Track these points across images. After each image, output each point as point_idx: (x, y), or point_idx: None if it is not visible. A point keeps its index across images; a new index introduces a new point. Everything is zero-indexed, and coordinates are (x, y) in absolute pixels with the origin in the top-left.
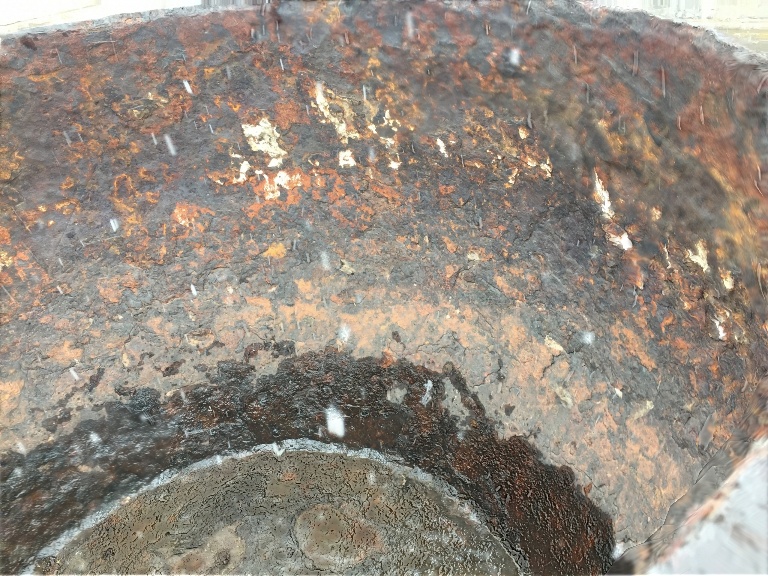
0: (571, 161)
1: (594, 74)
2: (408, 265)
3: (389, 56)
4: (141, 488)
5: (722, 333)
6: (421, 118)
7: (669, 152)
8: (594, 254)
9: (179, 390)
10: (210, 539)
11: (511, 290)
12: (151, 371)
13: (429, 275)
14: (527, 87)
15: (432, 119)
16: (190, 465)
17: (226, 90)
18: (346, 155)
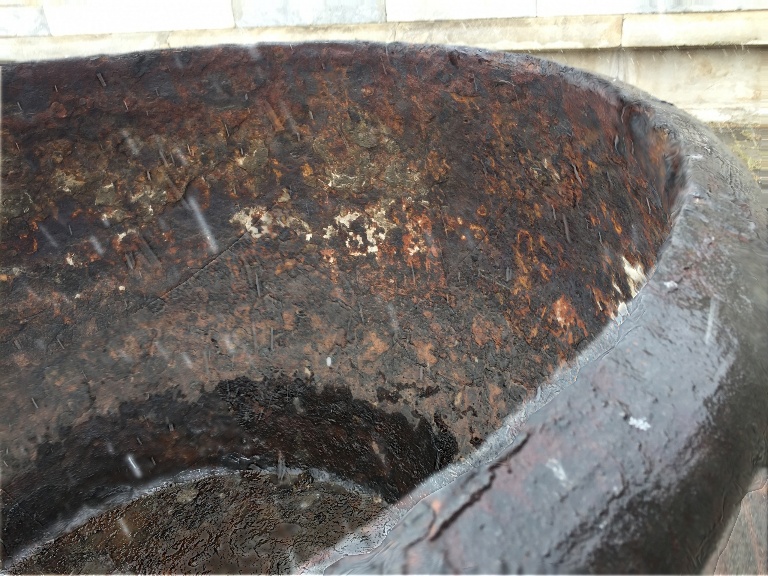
0: None
1: None
2: None
3: None
4: (393, 504)
5: None
6: None
7: None
8: None
9: (471, 466)
10: None
11: None
12: (466, 427)
13: None
14: None
15: None
16: None
17: (610, 201)
18: None
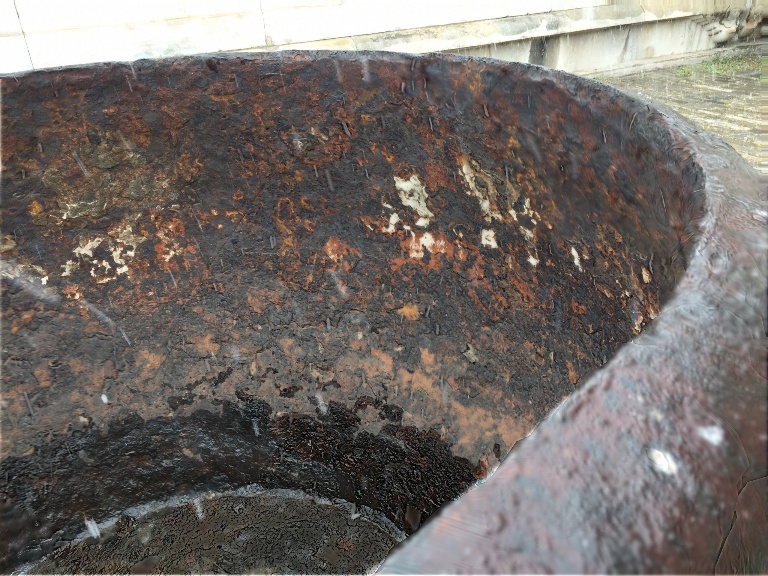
0: None
1: None
2: (529, 377)
3: (527, 139)
4: (228, 491)
5: None
6: (559, 218)
7: None
8: None
9: (289, 414)
10: (246, 572)
11: None
12: (271, 386)
13: (545, 398)
14: (646, 221)
15: (568, 223)
16: (275, 489)
17: (381, 139)
18: (489, 234)
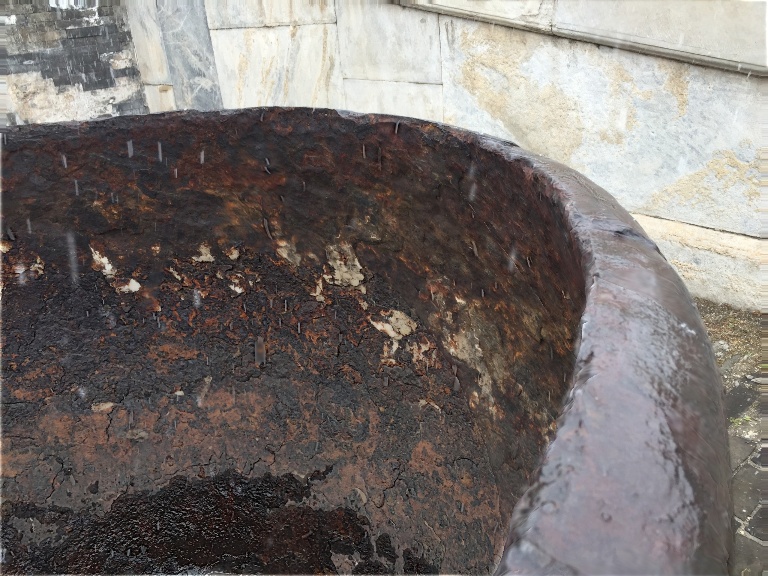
0: (63, 250)
1: (86, 170)
2: None
3: None
4: None
5: (240, 289)
6: None
7: (164, 199)
8: (108, 312)
9: None
10: None
11: (35, 394)
12: None
13: None
14: (5, 206)
15: None
16: None
17: None
18: None
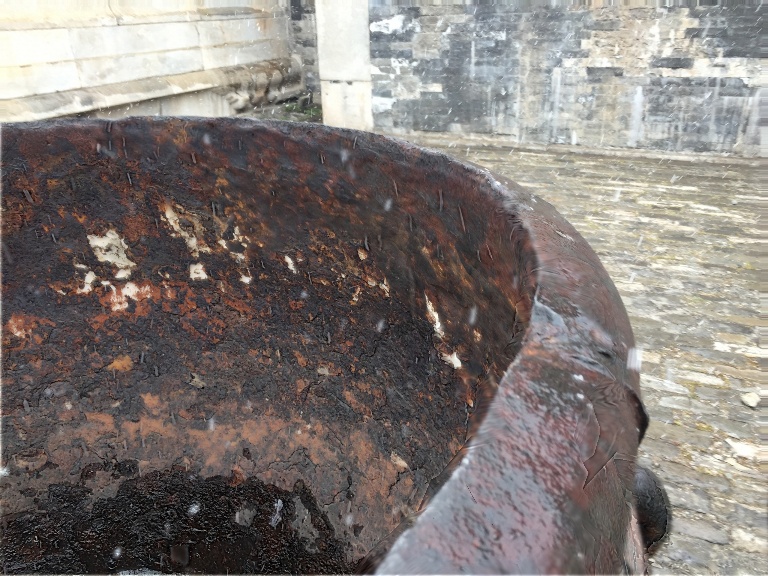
0: (405, 283)
1: (412, 206)
2: (260, 379)
3: (236, 176)
4: None
5: None
6: (269, 235)
7: (477, 281)
8: (430, 371)
9: (1, 519)
10: None
11: (359, 405)
12: None
13: (281, 389)
14: (361, 213)
15: (279, 237)
16: None
17: (71, 201)
18: (197, 268)
